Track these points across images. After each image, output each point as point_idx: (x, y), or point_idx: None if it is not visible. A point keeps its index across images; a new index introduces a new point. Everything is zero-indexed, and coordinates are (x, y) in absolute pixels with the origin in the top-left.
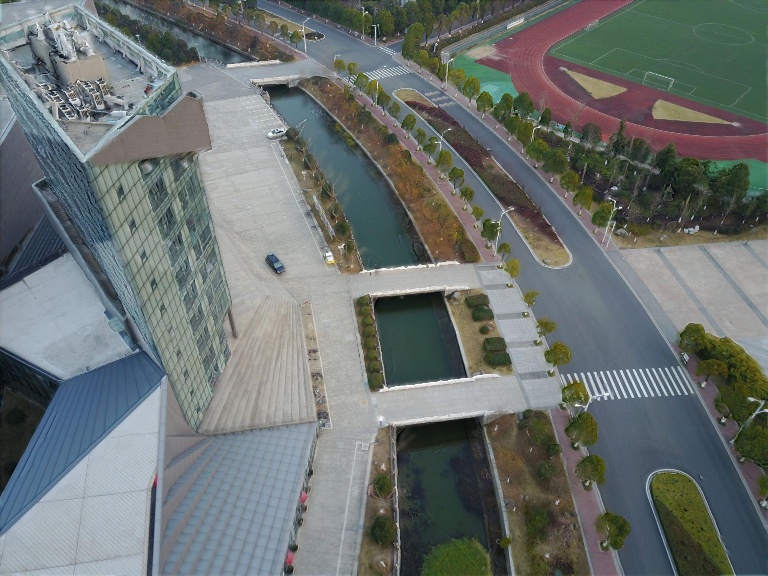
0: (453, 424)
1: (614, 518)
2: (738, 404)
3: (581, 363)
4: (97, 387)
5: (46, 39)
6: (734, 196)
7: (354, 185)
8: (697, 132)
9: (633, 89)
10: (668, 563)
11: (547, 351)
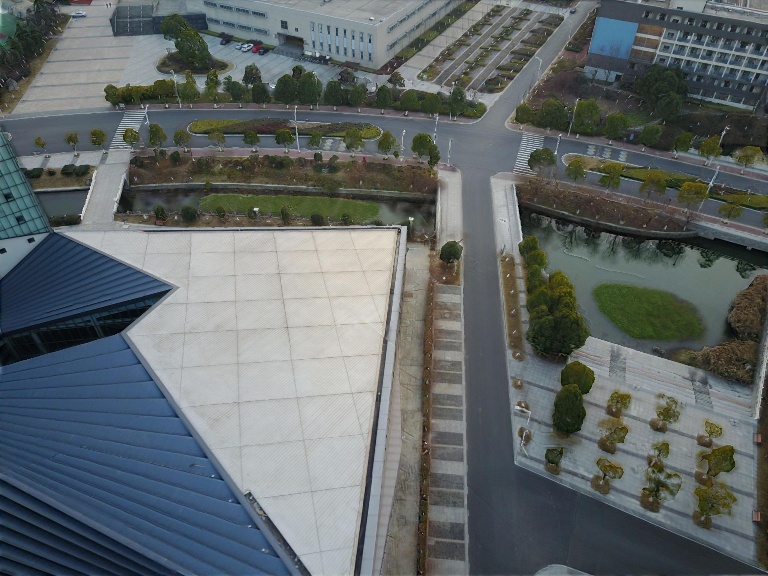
0: (122, 200)
1: (213, 130)
2: (166, 86)
3: (104, 142)
4: (28, 296)
5: None
6: (6, 52)
7: None
8: None
9: None
10: (235, 136)
11: (92, 142)
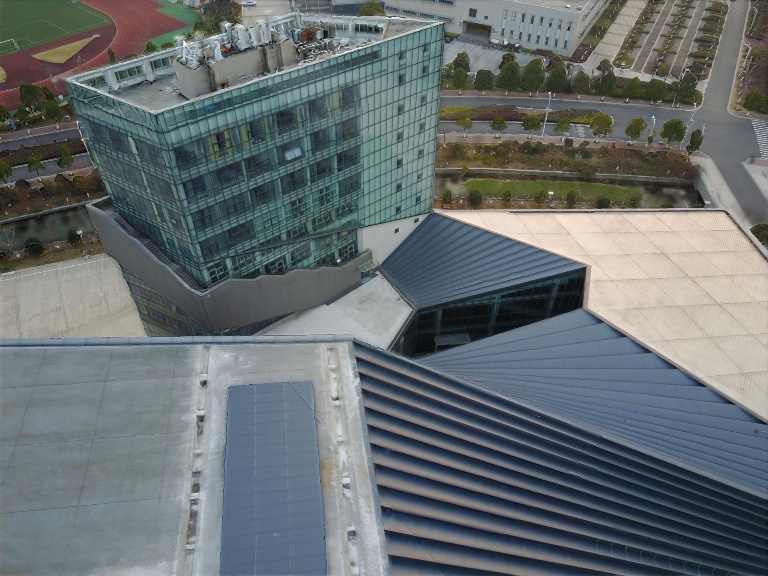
0: None
1: (463, 116)
2: None
3: None
4: (427, 274)
5: (223, 56)
6: None
7: (63, 240)
8: (98, 51)
9: (2, 63)
10: None
11: None
